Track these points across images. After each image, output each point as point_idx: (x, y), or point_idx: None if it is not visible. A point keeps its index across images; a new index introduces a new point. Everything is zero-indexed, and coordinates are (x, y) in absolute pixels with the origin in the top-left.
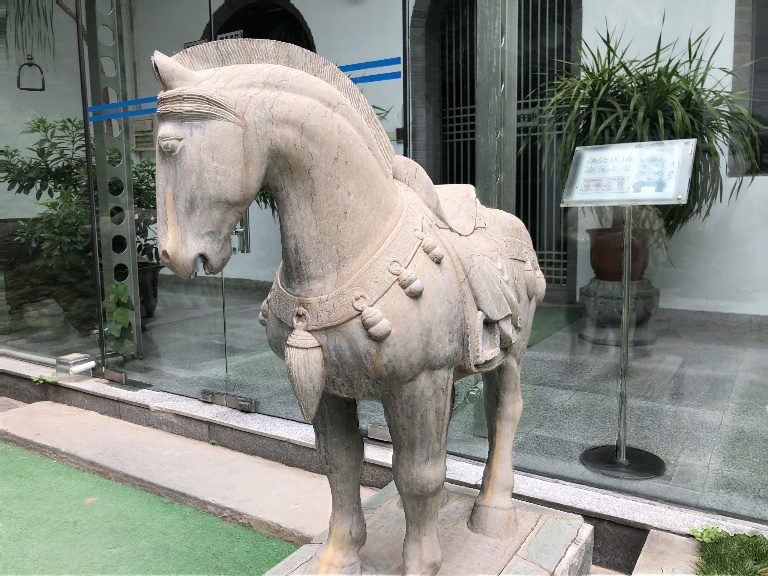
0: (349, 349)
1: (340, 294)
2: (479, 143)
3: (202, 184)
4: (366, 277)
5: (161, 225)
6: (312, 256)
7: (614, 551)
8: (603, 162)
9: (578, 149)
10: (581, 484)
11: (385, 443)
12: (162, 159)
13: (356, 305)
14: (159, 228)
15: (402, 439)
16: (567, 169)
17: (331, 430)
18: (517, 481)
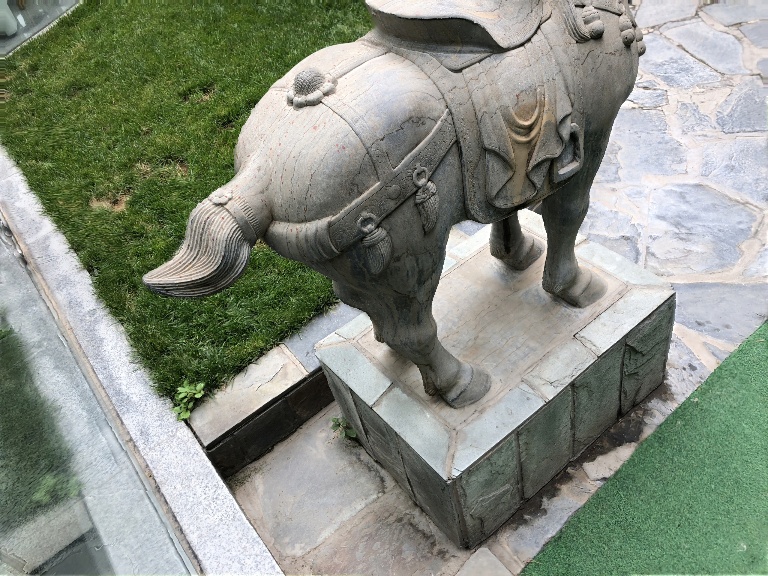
0: None
1: None
2: None
3: None
4: None
5: None
6: None
7: (233, 497)
8: None
9: None
10: (184, 561)
11: None
12: None
13: None
14: None
15: None
16: None
17: None
18: None
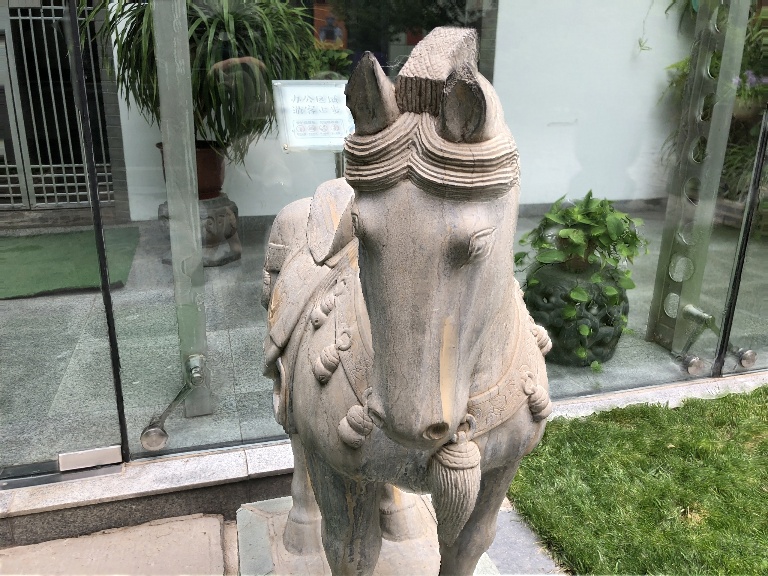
0: (507, 442)
1: (510, 381)
2: (164, 70)
3: (499, 298)
4: (525, 350)
5: (425, 381)
6: (487, 343)
7: None
8: (310, 102)
9: (276, 84)
10: None
11: (91, 469)
12: (452, 268)
13: (527, 389)
14: (415, 386)
15: (491, 506)
16: (273, 108)
17: (370, 529)
18: (283, 453)
